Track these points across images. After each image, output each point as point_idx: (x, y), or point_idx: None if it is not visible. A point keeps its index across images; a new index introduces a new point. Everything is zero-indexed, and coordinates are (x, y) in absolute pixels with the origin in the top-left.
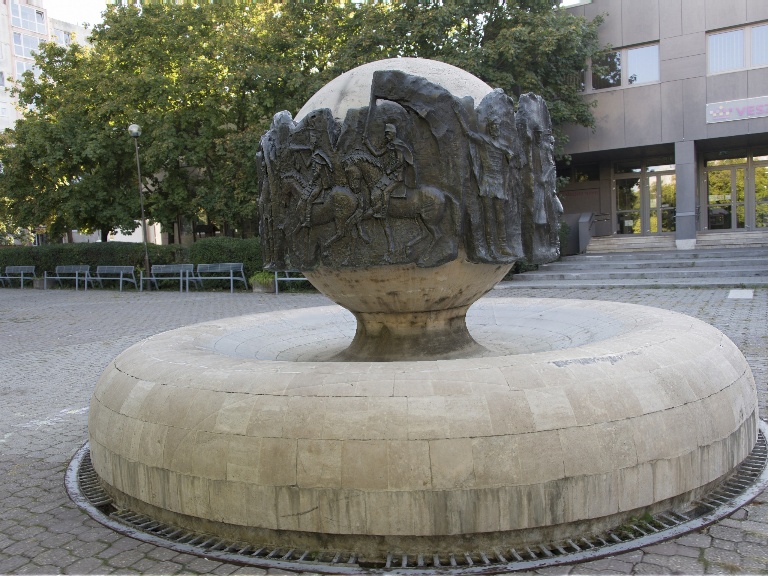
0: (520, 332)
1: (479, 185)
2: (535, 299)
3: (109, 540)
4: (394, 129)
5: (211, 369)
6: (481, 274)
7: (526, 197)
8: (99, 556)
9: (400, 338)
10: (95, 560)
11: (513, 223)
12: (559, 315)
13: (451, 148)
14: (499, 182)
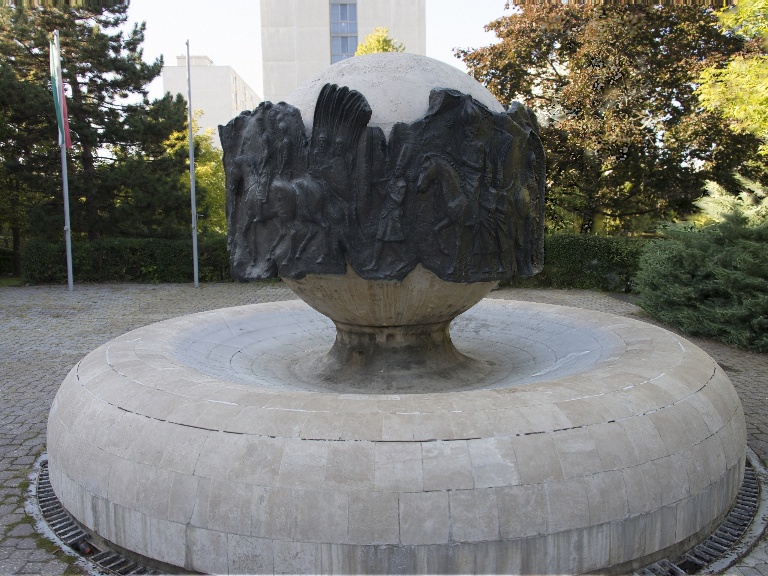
0: (278, 344)
1: None
2: (179, 322)
3: (752, 436)
4: None
5: (667, 331)
6: None
7: None
8: (761, 432)
9: None
10: (764, 430)
11: None
12: (254, 324)
13: None
14: None
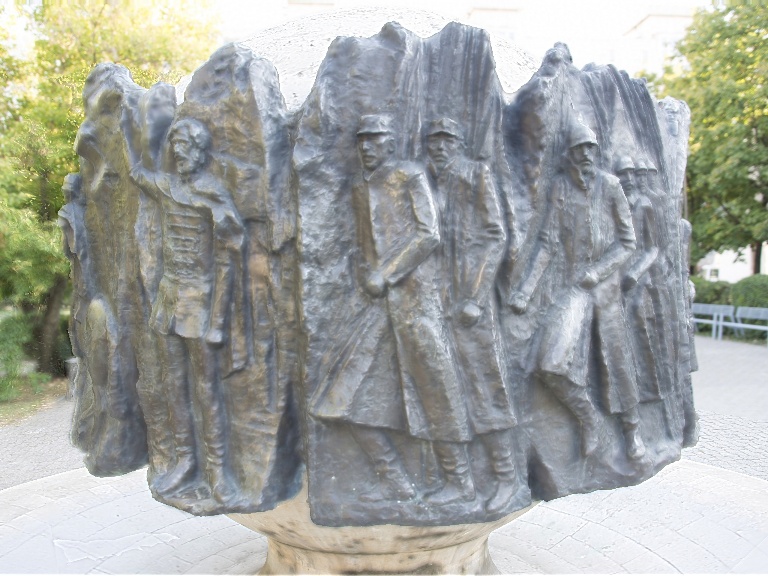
0: None
1: (153, 301)
2: None
3: None
4: (67, 183)
5: None
6: (300, 504)
7: (299, 332)
8: None
9: (268, 575)
10: None
11: (252, 403)
12: None
13: (115, 214)
14: (193, 293)
